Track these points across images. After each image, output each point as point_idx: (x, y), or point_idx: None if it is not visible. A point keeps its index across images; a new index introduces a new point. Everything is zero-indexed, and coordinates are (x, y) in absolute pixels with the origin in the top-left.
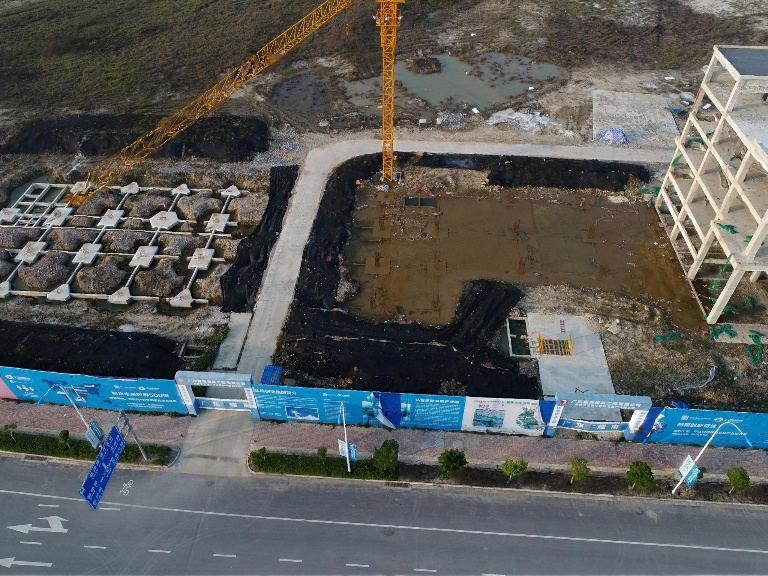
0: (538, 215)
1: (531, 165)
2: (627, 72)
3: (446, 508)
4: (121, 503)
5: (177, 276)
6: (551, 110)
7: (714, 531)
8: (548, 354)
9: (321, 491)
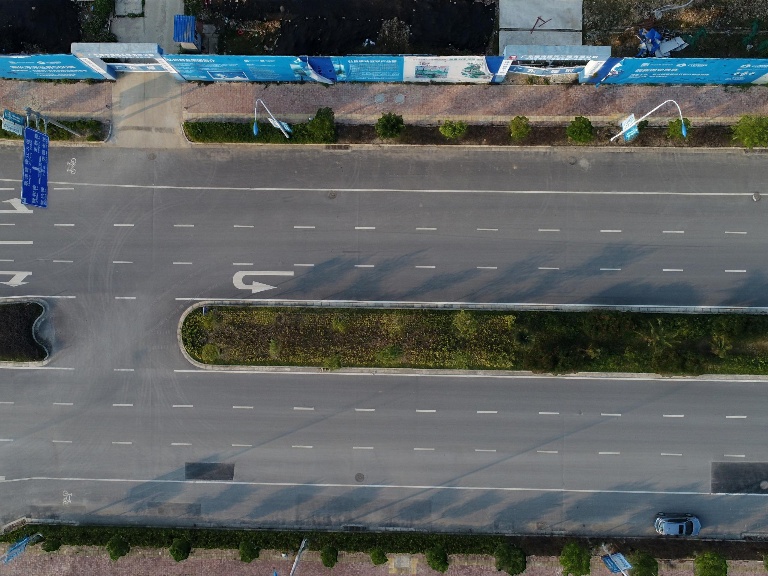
0: None
1: None
2: None
3: (385, 169)
4: (72, 182)
5: None
6: None
7: (639, 177)
8: None
9: (263, 158)
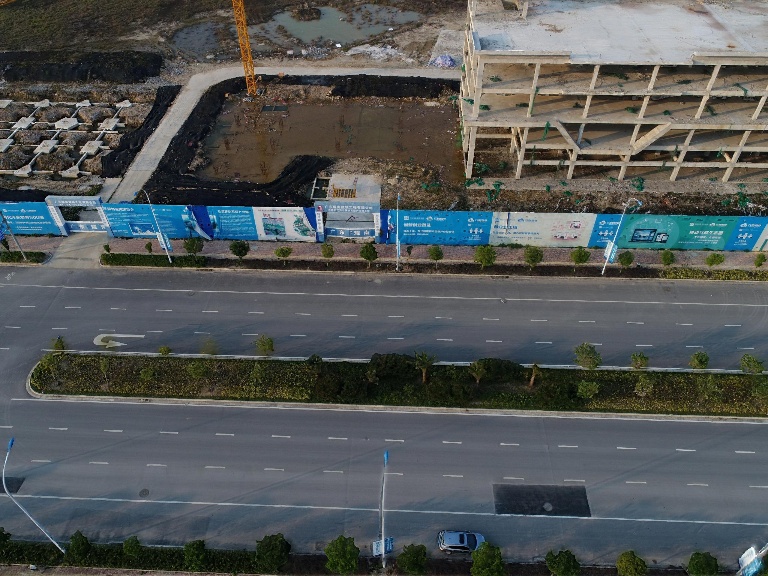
0: (365, 115)
1: (366, 80)
2: None
3: (235, 281)
4: (5, 283)
5: (69, 158)
6: (401, 44)
7: (417, 288)
8: (338, 197)
9: (149, 274)
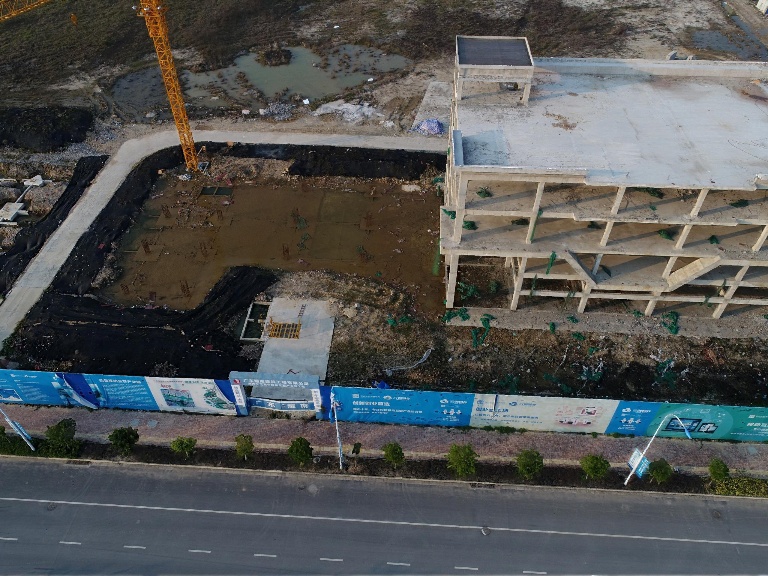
0: (327, 203)
1: (332, 155)
2: None
3: (116, 484)
4: None
5: None
6: (381, 101)
7: (366, 504)
8: (277, 337)
9: (1, 469)
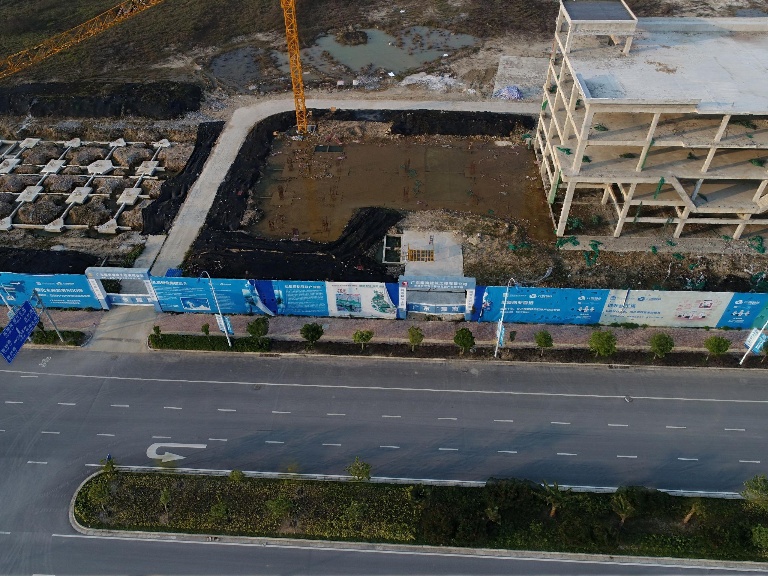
0: (430, 157)
1: (429, 116)
2: (536, 40)
3: (307, 370)
4: (39, 372)
5: (106, 209)
6: (460, 73)
7: (522, 382)
8: (414, 261)
9: (206, 361)
